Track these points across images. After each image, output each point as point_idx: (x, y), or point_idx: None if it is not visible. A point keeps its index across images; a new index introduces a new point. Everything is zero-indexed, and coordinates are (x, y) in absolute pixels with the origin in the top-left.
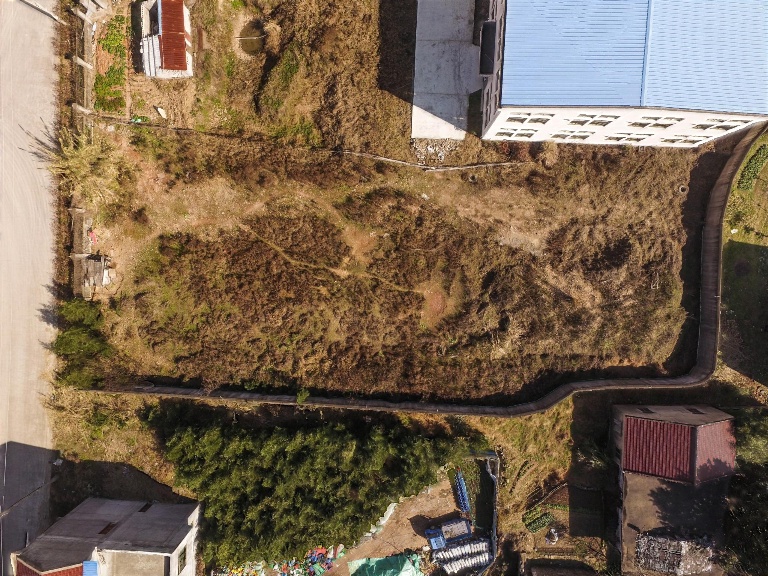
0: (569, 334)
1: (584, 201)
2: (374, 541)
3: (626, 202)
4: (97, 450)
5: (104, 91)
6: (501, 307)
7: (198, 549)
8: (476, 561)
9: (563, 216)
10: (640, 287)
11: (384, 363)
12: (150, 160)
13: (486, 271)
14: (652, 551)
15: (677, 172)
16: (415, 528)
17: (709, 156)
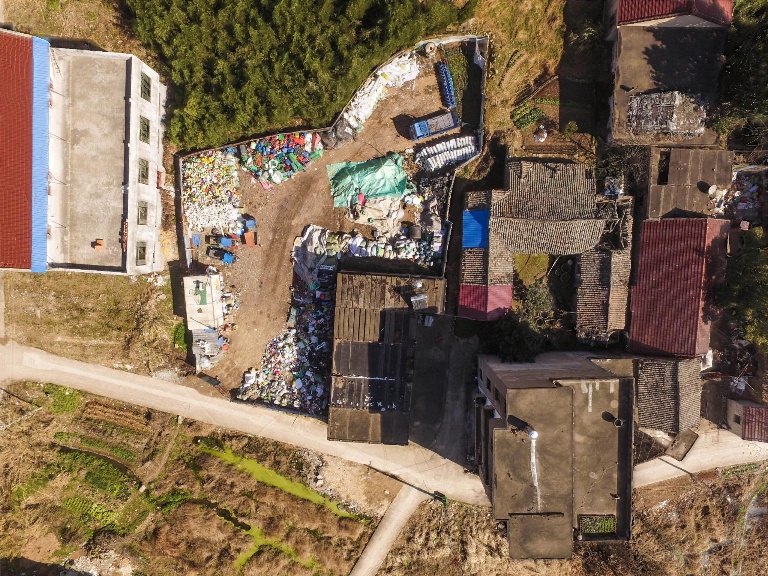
0: None
1: None
2: (355, 143)
3: None
4: (54, 23)
5: None
6: None
7: (166, 134)
8: (462, 153)
9: None
10: None
11: None
12: None
13: None
14: (645, 110)
15: None
16: (398, 129)
17: None
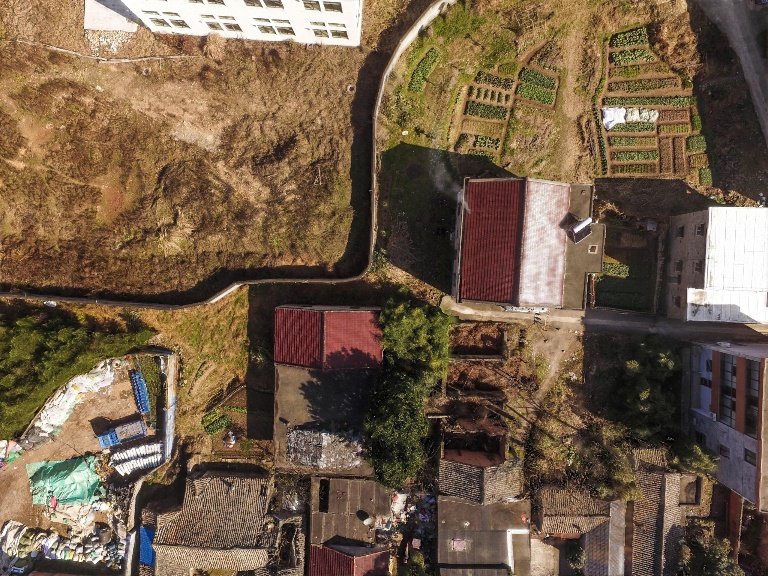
0: (237, 229)
1: (255, 98)
2: (54, 443)
3: (297, 100)
4: None
5: None
6: (171, 201)
7: None
8: (148, 462)
9: (236, 112)
10: (303, 182)
11: (57, 256)
12: None
13: (161, 166)
14: (300, 445)
15: (345, 71)
16: (95, 430)
17: (375, 56)
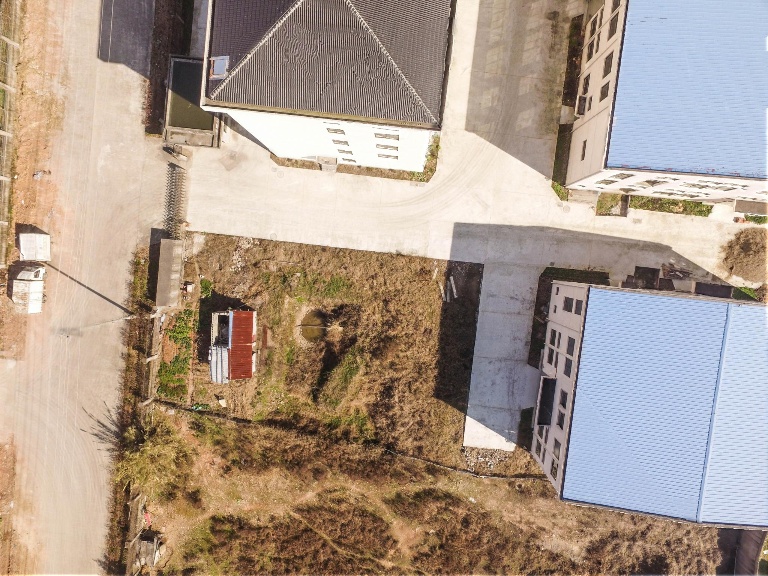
0: None
1: (625, 516)
2: None
3: None
4: None
5: (168, 379)
6: None
7: None
8: None
9: (604, 528)
10: None
11: None
12: (207, 445)
13: (526, 573)
14: None
15: None
16: None
17: None
